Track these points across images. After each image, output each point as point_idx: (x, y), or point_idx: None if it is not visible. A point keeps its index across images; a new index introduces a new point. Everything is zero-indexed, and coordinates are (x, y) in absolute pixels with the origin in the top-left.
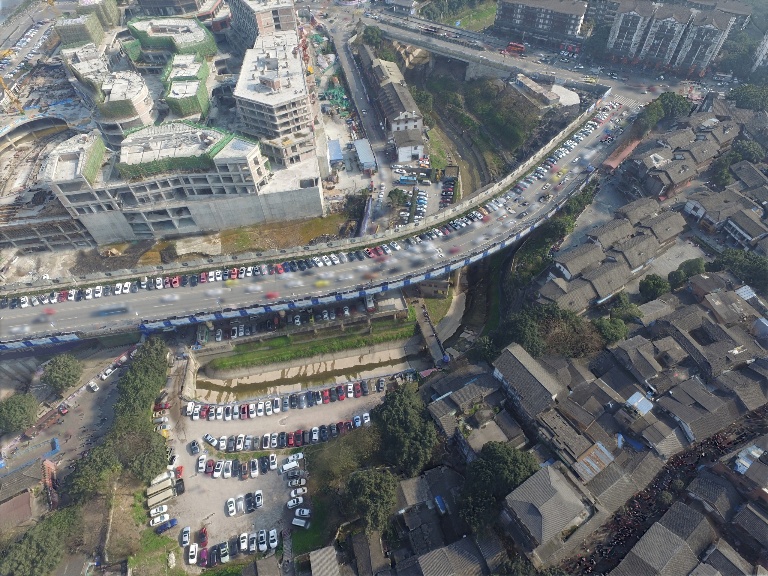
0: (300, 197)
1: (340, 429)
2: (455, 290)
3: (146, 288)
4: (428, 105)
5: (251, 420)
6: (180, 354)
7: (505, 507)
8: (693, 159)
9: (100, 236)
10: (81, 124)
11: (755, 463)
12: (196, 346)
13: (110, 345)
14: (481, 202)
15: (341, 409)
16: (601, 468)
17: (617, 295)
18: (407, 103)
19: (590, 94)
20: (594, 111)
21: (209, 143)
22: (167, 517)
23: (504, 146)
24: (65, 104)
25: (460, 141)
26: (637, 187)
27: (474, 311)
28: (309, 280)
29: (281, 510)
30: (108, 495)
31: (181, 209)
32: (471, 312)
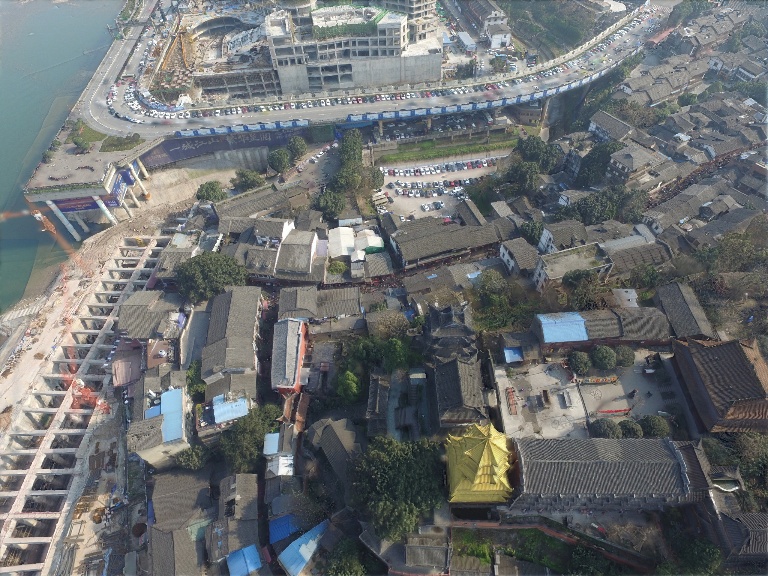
0: (428, 62)
1: (483, 178)
2: (541, 125)
3: (341, 103)
4: (507, 13)
5: (423, 176)
6: (364, 147)
7: (608, 166)
8: (715, 32)
9: (286, 87)
10: (252, 20)
11: (752, 155)
12: (374, 143)
13: (318, 140)
14: (561, 63)
15: (480, 172)
16: (660, 160)
17: (663, 102)
18: (496, 6)
19: (634, 4)
20: (638, 14)
21: (371, 16)
22: (387, 211)
23: (567, 43)
24: (233, 9)
25: (530, 44)
26: (674, 51)
27: (556, 137)
28: (450, 100)
29: (456, 209)
30: (352, 196)
31: (343, 69)
32: (554, 137)
